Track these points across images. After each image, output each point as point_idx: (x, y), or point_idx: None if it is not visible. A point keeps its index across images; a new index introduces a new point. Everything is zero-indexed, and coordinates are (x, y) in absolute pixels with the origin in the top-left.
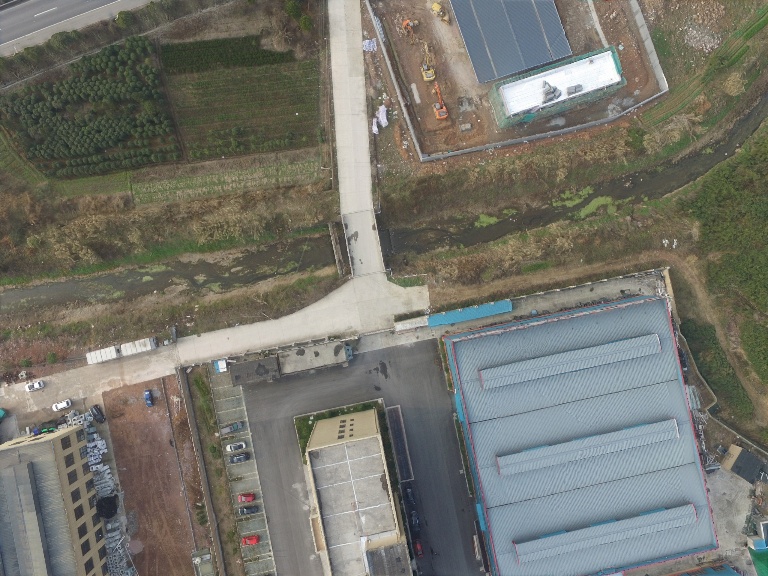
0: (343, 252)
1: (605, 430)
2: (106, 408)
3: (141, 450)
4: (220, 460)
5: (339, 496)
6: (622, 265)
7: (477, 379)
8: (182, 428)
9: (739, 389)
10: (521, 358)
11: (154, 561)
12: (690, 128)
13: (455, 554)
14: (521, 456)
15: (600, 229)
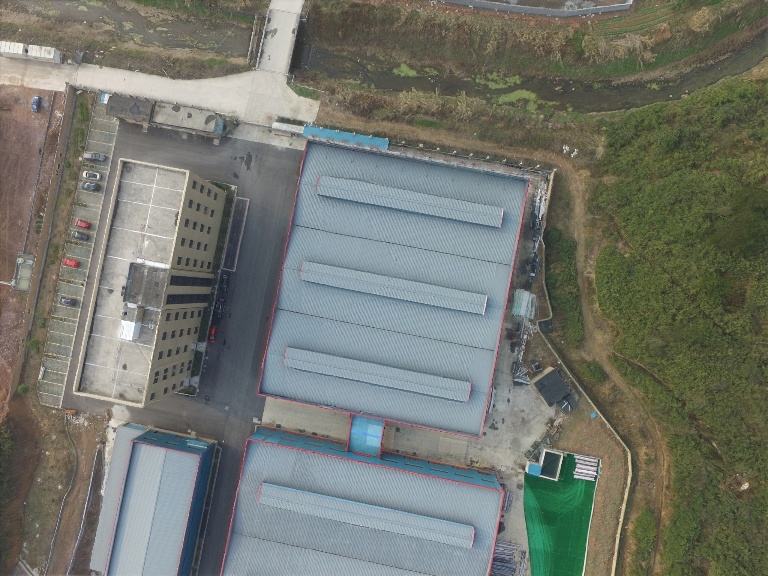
0: (258, 45)
1: (416, 279)
2: None
3: (13, 147)
4: (74, 182)
5: (134, 214)
6: (513, 154)
7: (316, 185)
8: (53, 141)
9: (576, 312)
10: (364, 180)
11: None
12: (640, 52)
13: (244, 354)
14: (325, 268)
15: (509, 116)
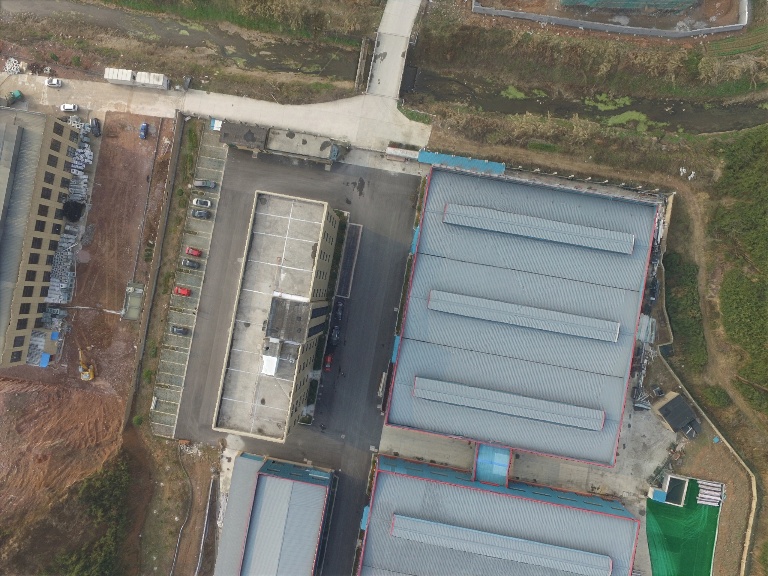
0: (366, 68)
1: (546, 307)
2: (105, 126)
3: (120, 174)
4: (184, 210)
5: (269, 246)
6: (629, 177)
7: (441, 212)
8: (162, 168)
9: (699, 336)
10: (491, 207)
11: (94, 276)
12: (754, 73)
13: (360, 382)
14: (454, 297)
15: (622, 138)
